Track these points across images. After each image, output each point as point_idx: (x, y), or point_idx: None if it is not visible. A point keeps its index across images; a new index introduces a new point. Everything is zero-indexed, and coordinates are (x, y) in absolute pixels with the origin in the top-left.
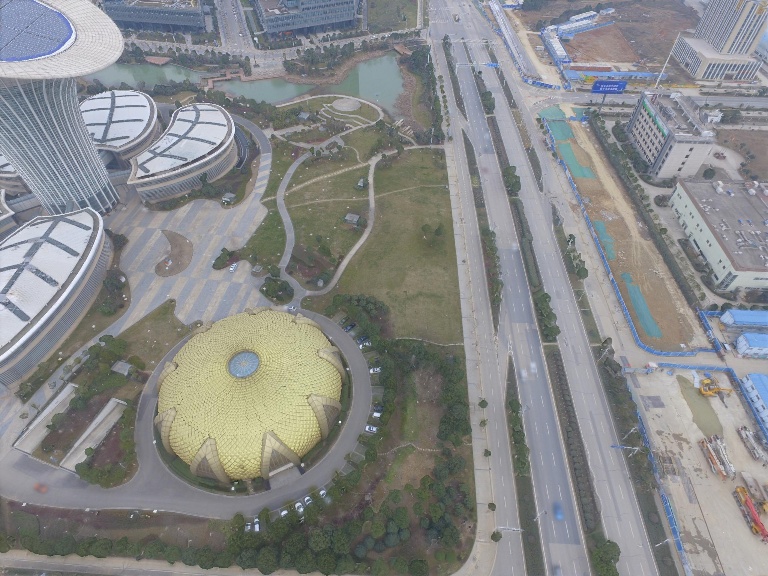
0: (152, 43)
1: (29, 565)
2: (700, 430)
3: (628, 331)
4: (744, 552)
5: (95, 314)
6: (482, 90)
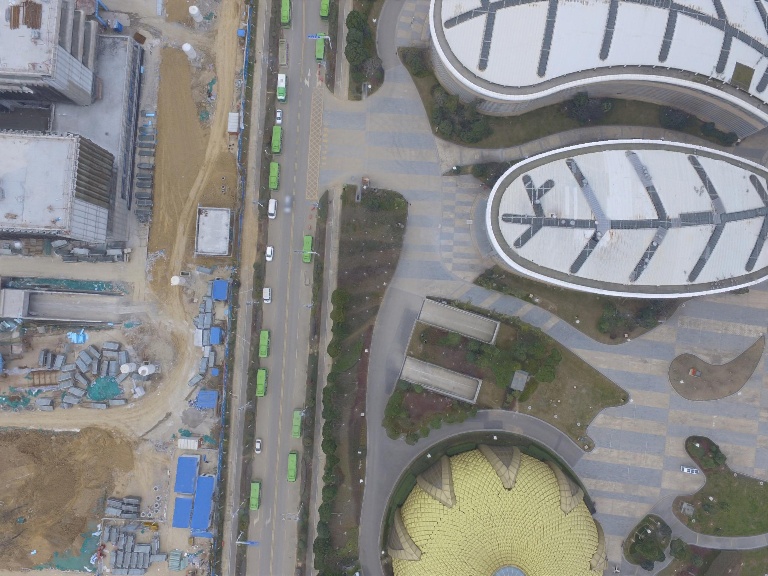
0: None
1: (321, 371)
2: None
3: None
4: None
5: (599, 308)
6: None
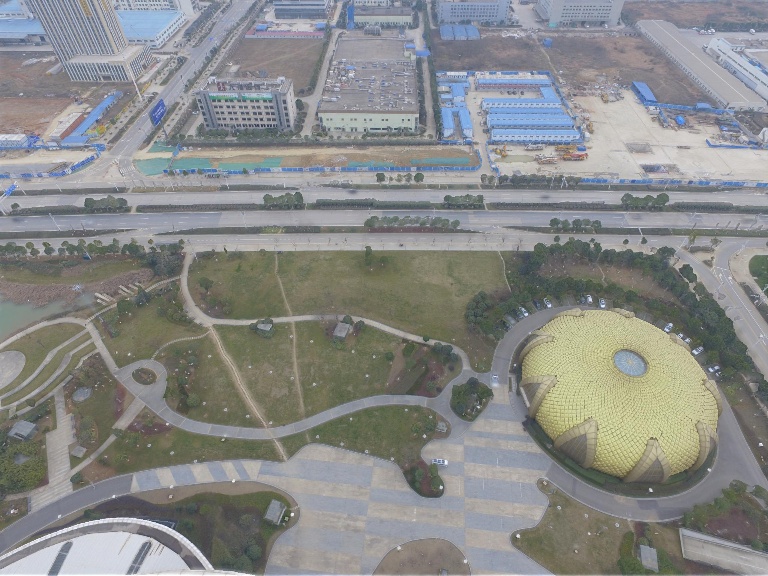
0: None
1: None
2: (531, 162)
3: (464, 172)
4: (594, 165)
5: None
6: (70, 207)
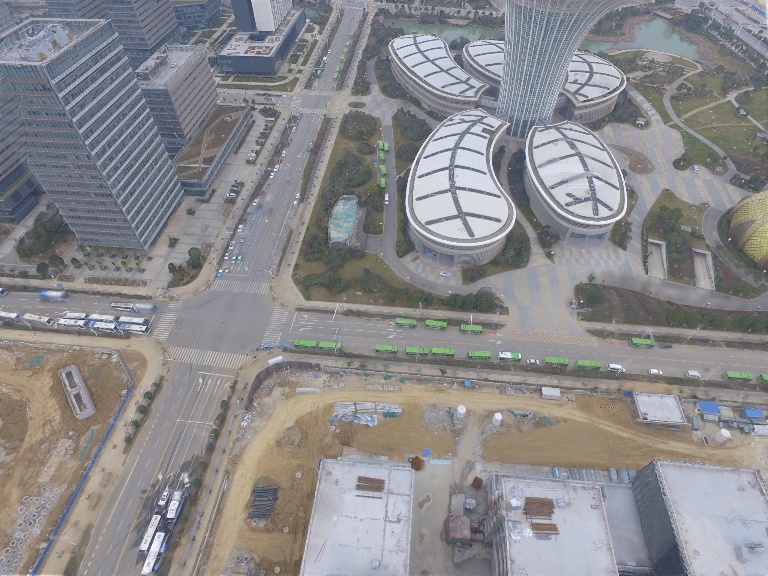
0: (439, 8)
1: (737, 340)
2: None
3: None
4: None
5: None
6: None
